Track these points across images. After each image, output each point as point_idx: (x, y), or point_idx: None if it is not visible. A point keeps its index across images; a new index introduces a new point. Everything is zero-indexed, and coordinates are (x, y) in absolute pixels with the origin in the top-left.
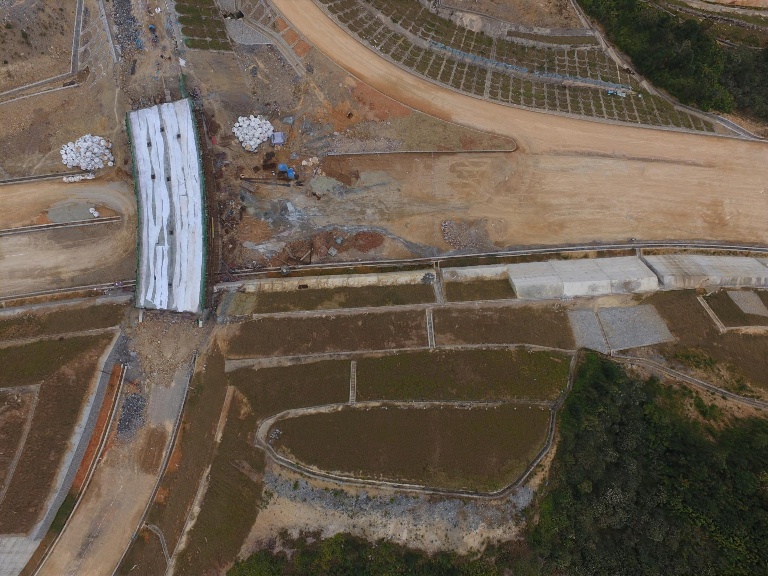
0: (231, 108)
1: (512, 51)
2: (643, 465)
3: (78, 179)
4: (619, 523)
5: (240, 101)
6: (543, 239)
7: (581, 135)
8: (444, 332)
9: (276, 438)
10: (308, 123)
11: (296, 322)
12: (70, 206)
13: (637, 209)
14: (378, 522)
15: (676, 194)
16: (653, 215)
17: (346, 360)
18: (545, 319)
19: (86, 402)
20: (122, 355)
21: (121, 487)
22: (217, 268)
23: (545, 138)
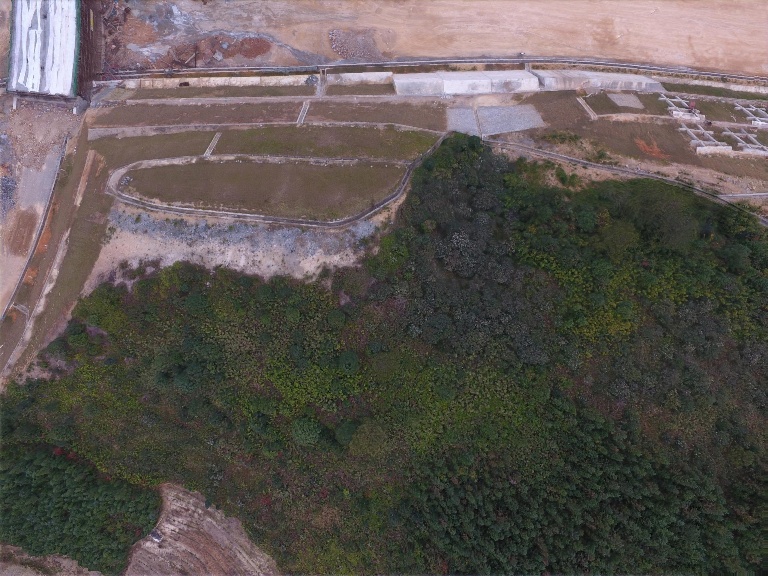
0: None
1: None
2: (498, 224)
3: None
4: (467, 270)
5: None
6: (432, 51)
7: None
8: (315, 114)
9: (126, 184)
10: None
11: (169, 107)
12: None
13: (527, 25)
14: (216, 249)
15: (566, 11)
16: (543, 31)
17: (211, 131)
18: (422, 112)
19: None
20: None
21: None
22: (99, 68)
23: None
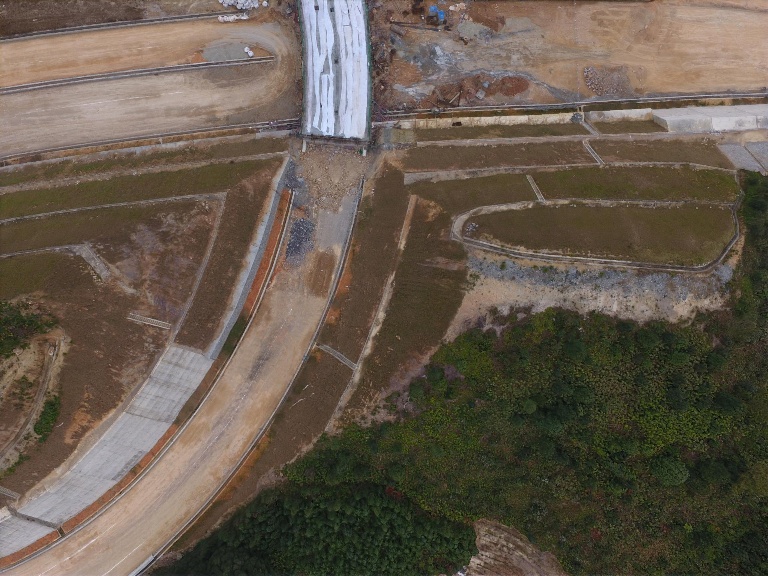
0: None
1: None
2: None
3: (233, 19)
4: None
5: None
6: (680, 87)
7: None
8: (608, 154)
9: (473, 230)
10: None
11: (461, 148)
12: (225, 45)
13: None
14: (588, 295)
15: None
16: None
17: (521, 174)
18: (698, 149)
19: (260, 221)
20: (291, 180)
21: (291, 310)
22: None
23: None
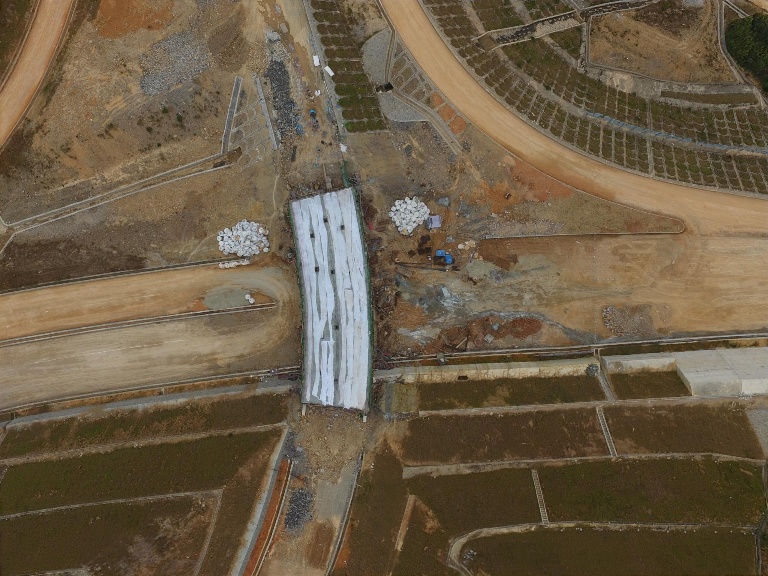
0: (389, 192)
1: (668, 115)
2: None
3: (233, 265)
4: None
5: (396, 183)
6: (709, 325)
7: (754, 215)
8: (623, 437)
9: (471, 559)
10: (465, 205)
11: (465, 421)
12: (226, 293)
13: None
14: None
15: None
16: None
17: (526, 469)
18: (724, 420)
19: (258, 500)
20: (289, 451)
21: None
22: None
23: (715, 218)
